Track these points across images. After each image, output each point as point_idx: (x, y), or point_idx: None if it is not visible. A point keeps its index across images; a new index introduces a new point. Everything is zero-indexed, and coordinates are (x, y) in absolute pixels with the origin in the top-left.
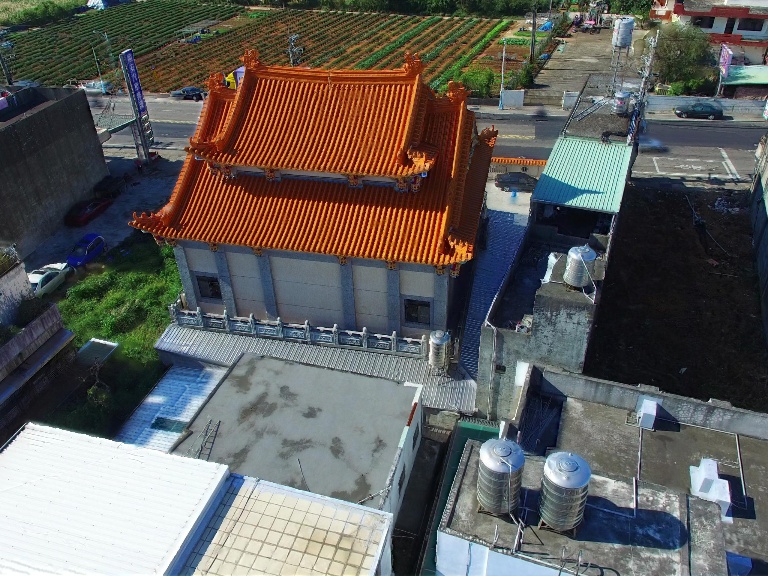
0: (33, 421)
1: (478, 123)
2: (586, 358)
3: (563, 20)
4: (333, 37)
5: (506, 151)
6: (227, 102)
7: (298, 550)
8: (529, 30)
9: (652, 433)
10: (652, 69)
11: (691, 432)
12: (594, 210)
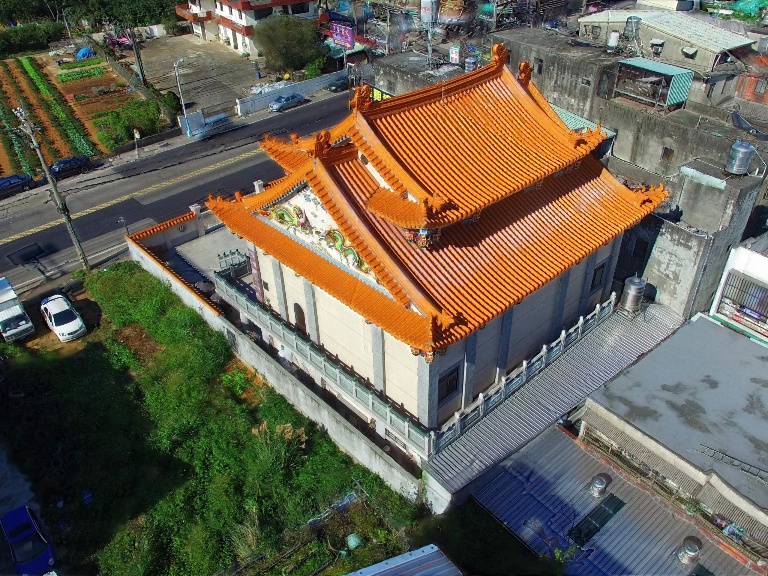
0: None
1: (198, 155)
2: (748, 224)
3: (96, 43)
4: None
5: (271, 166)
6: (336, 166)
7: None
8: (69, 61)
9: None
10: (390, 45)
11: None
12: None
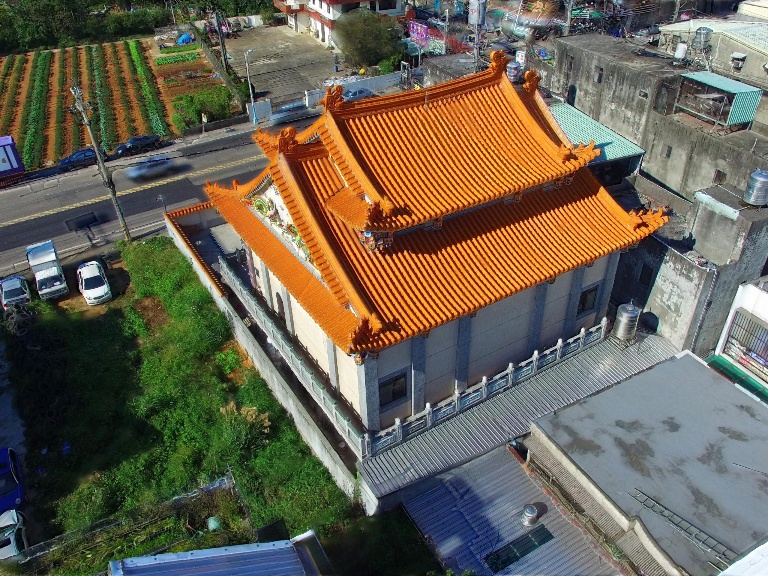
0: None
1: None
2: (767, 261)
3: (196, 30)
4: None
5: None
6: (303, 162)
7: None
8: (170, 46)
9: None
10: (448, 45)
11: None
12: (630, 156)
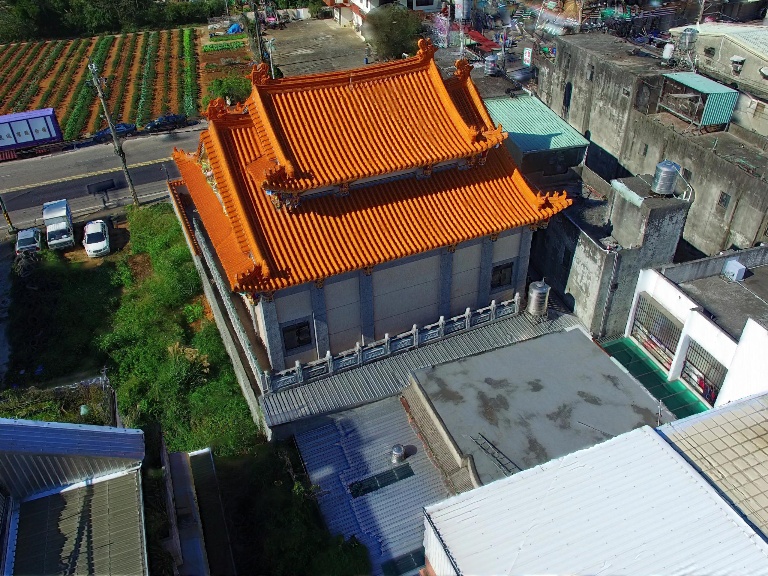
0: (221, 570)
1: None
2: (677, 250)
3: (247, 20)
4: (4, 75)
5: None
6: (232, 130)
7: (764, 447)
8: (220, 35)
9: (745, 282)
10: (450, 40)
11: (759, 271)
12: (574, 147)
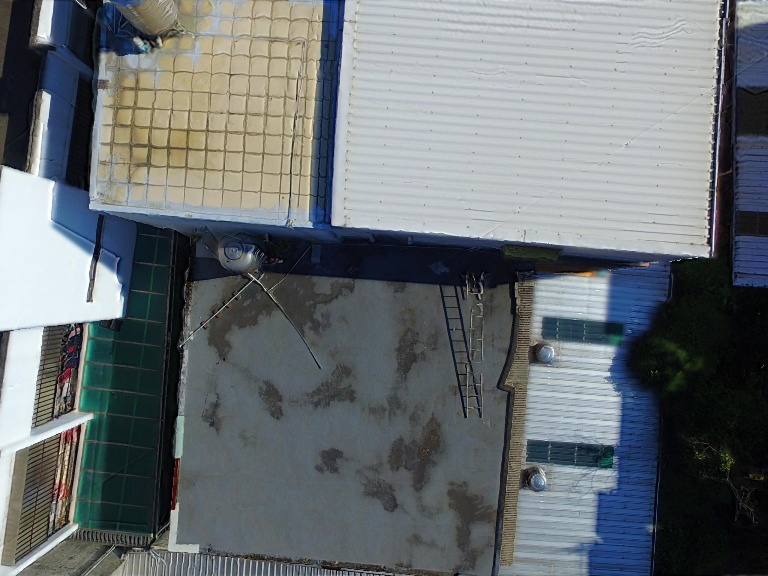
0: None
1: None
2: None
3: None
4: None
5: None
6: None
7: (199, 132)
8: None
9: None
10: None
11: None
12: None
